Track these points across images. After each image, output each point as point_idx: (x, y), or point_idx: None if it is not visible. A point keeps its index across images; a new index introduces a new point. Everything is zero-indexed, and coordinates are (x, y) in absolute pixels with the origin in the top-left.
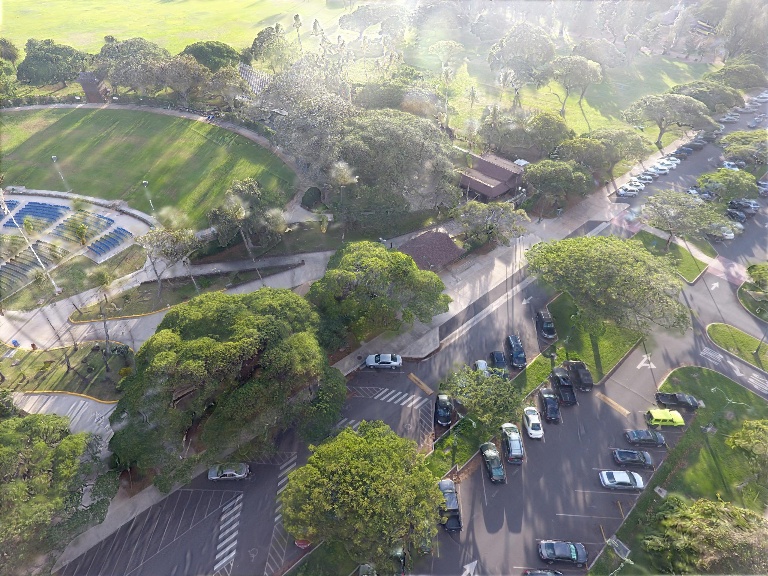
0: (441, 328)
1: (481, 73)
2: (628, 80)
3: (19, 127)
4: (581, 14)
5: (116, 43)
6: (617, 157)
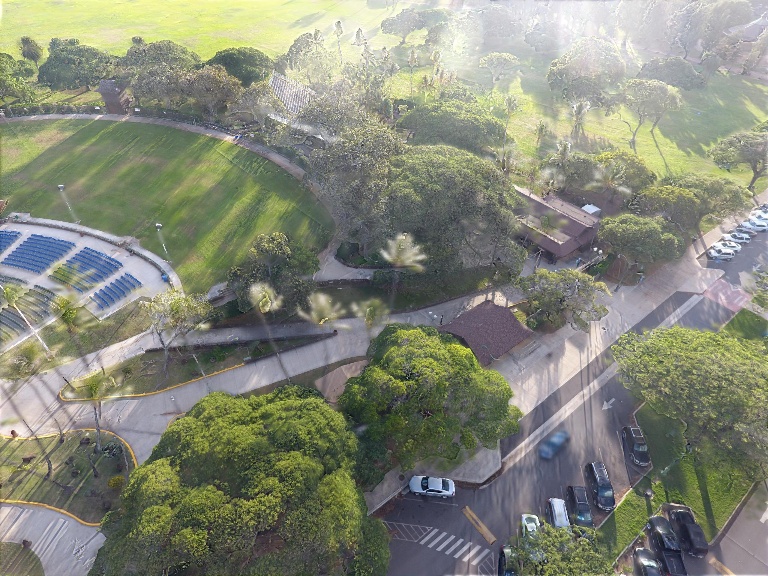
0: (502, 439)
1: (537, 90)
2: (705, 105)
3: (32, 140)
4: (649, 25)
5: (143, 46)
6: (707, 209)
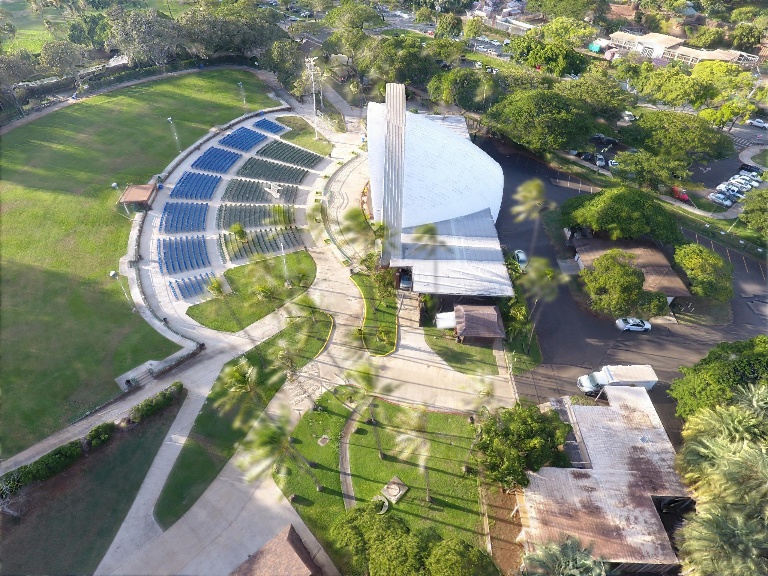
0: None
1: (39, 27)
2: None
3: None
4: None
5: None
6: None
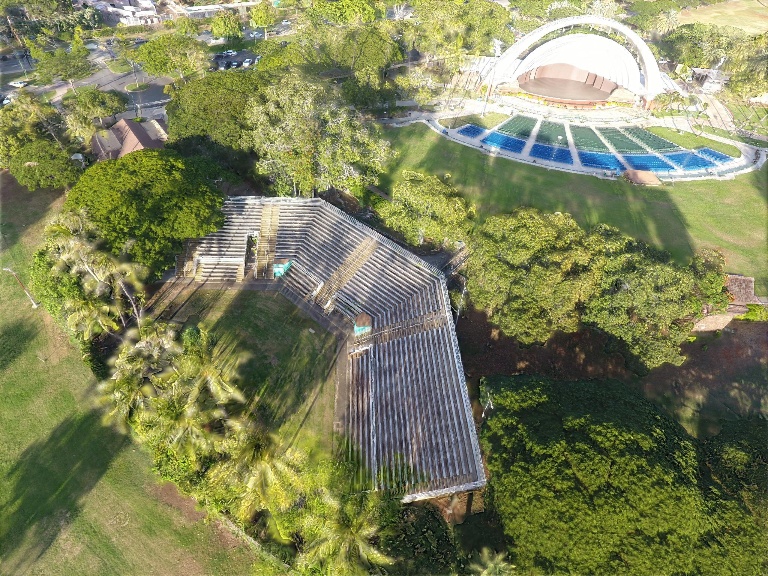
0: None
1: None
2: None
3: (737, 253)
4: None
5: None
6: None
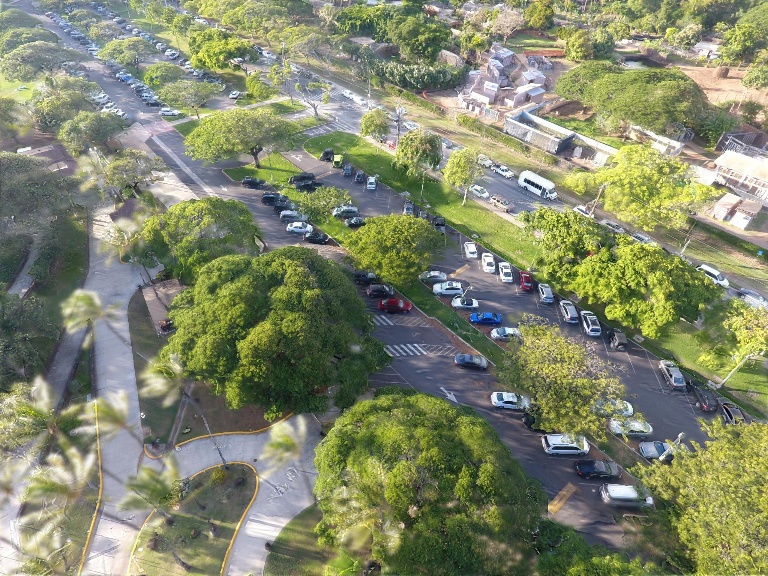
0: None
1: None
2: None
3: None
4: None
5: None
6: None
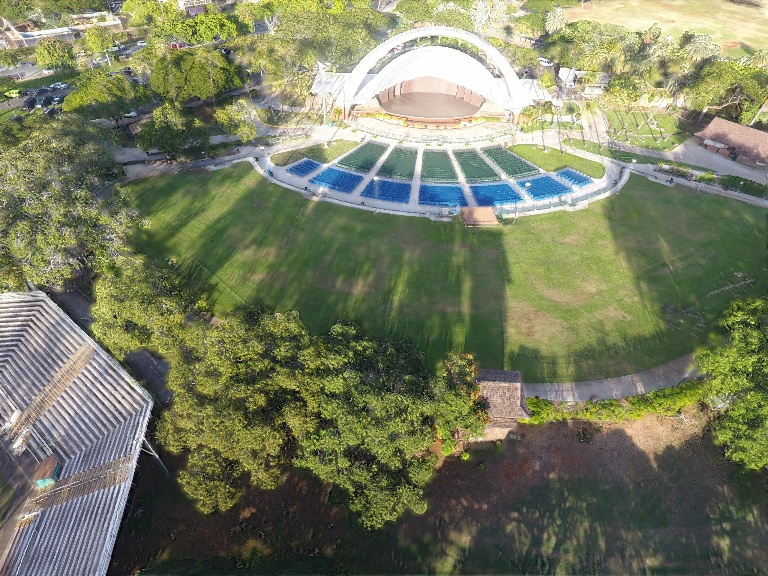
0: None
1: None
2: None
3: (555, 317)
4: None
5: None
6: None
